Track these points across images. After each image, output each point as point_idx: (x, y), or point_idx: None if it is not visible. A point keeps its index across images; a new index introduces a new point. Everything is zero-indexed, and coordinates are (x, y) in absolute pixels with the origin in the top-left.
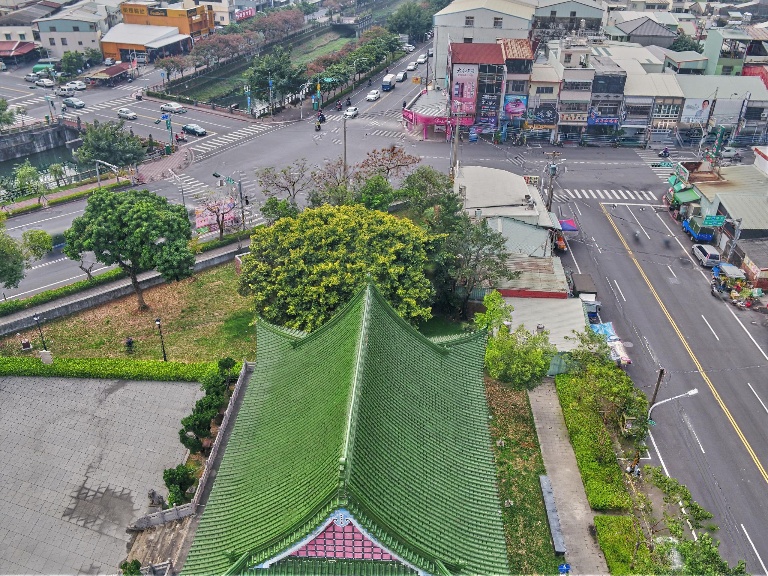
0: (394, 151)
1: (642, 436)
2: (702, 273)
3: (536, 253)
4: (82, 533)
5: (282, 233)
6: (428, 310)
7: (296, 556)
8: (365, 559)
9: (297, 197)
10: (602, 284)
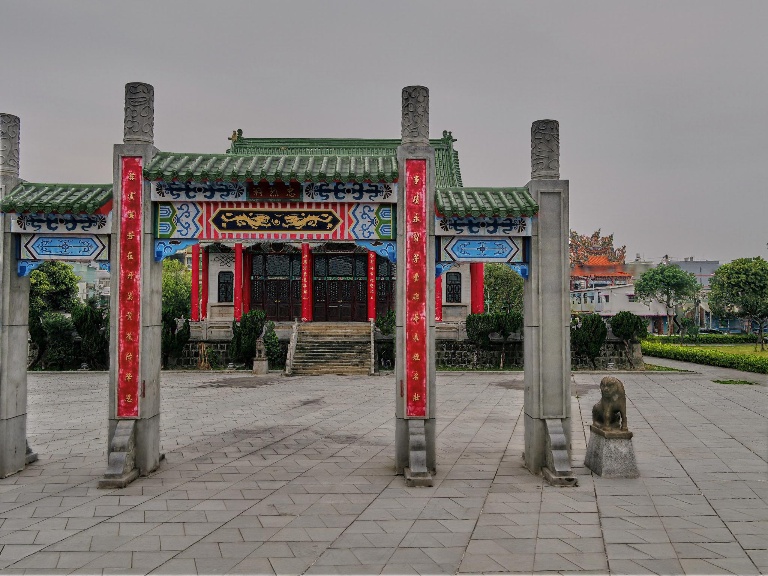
0: None
1: None
2: None
3: None
4: (291, 382)
5: None
6: None
7: None
8: None
9: None
10: None
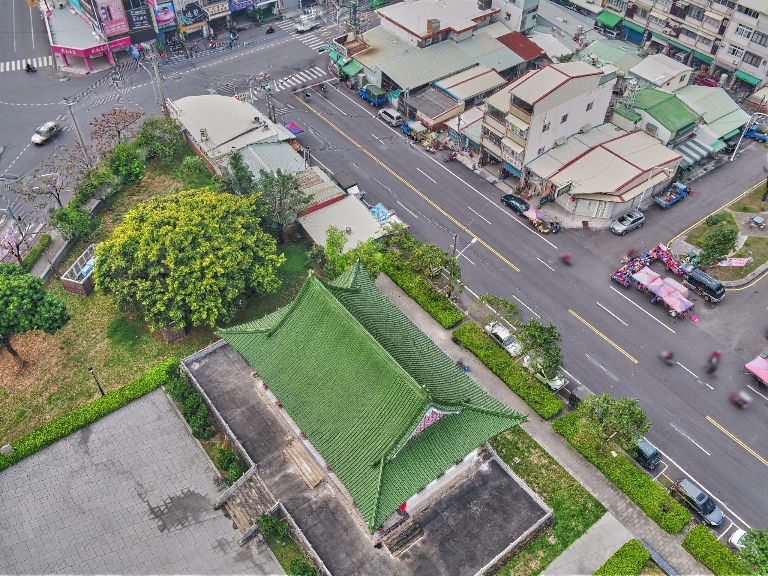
0: (116, 114)
1: (459, 277)
2: (396, 132)
3: (297, 168)
4: (188, 531)
5: (130, 248)
6: (282, 256)
7: None
8: (433, 423)
9: (61, 195)
10: (345, 170)
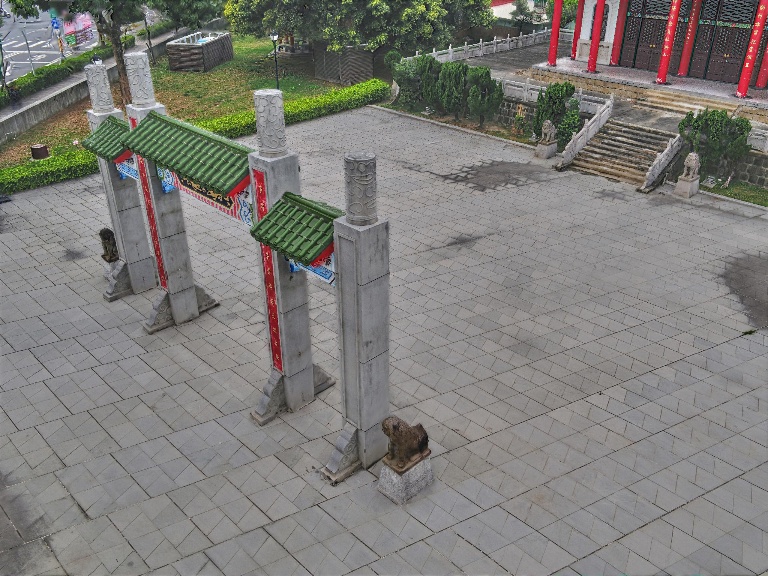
0: None
1: None
2: None
3: None
4: (531, 187)
5: None
6: None
7: None
8: None
9: None
10: None
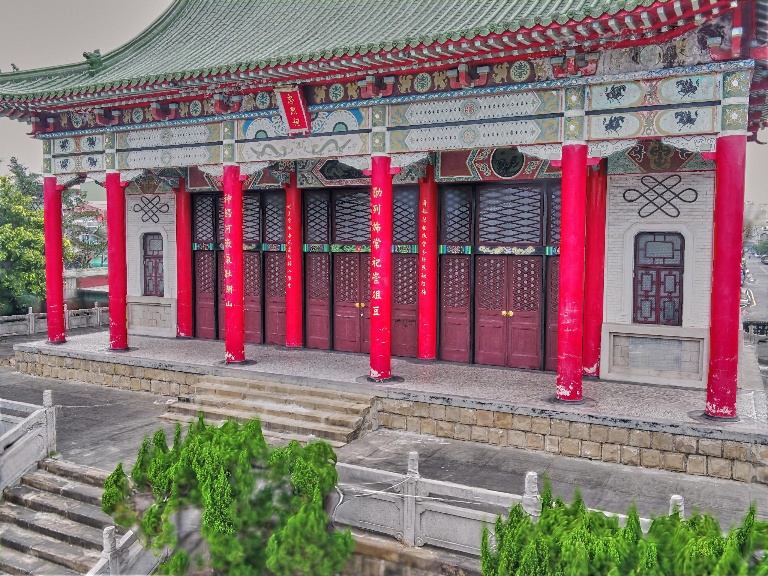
0: None
1: None
2: None
3: None
4: None
5: None
6: None
7: None
8: None
9: None
10: None
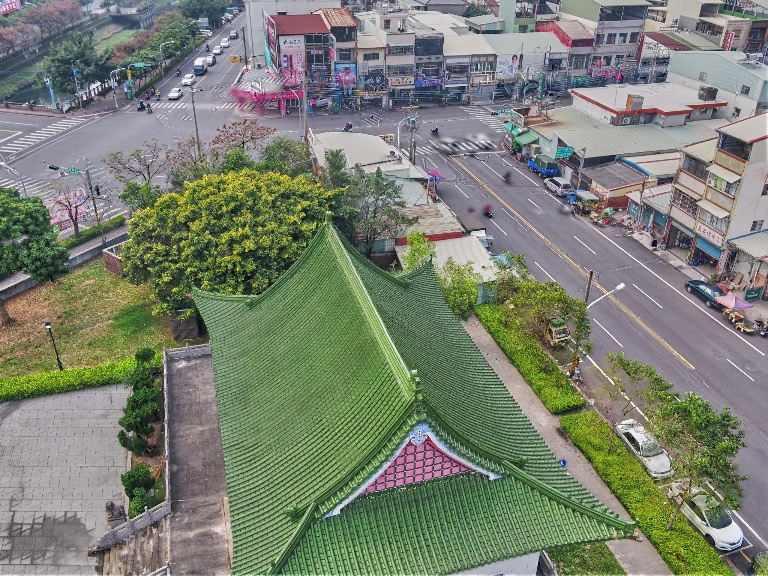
0: (246, 124)
1: (585, 335)
2: (560, 202)
3: (418, 202)
4: (33, 571)
5: (168, 210)
6: None
7: (364, 494)
8: (435, 478)
9: None
10: None
